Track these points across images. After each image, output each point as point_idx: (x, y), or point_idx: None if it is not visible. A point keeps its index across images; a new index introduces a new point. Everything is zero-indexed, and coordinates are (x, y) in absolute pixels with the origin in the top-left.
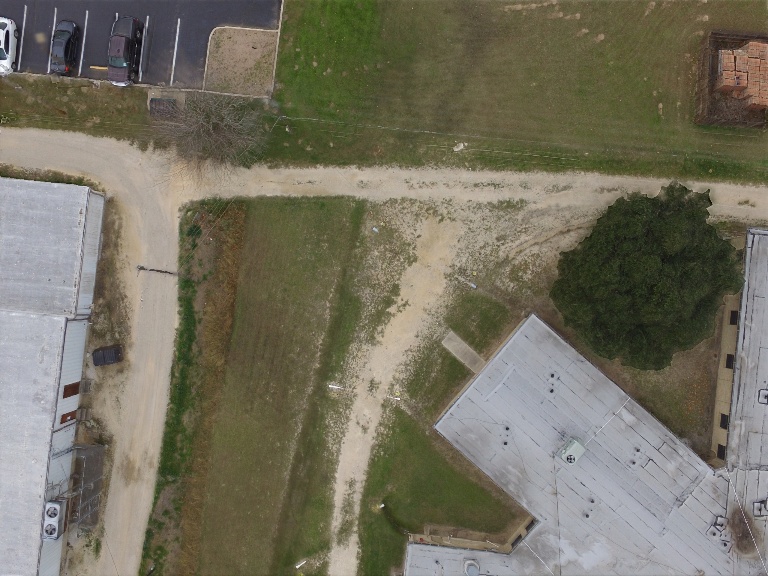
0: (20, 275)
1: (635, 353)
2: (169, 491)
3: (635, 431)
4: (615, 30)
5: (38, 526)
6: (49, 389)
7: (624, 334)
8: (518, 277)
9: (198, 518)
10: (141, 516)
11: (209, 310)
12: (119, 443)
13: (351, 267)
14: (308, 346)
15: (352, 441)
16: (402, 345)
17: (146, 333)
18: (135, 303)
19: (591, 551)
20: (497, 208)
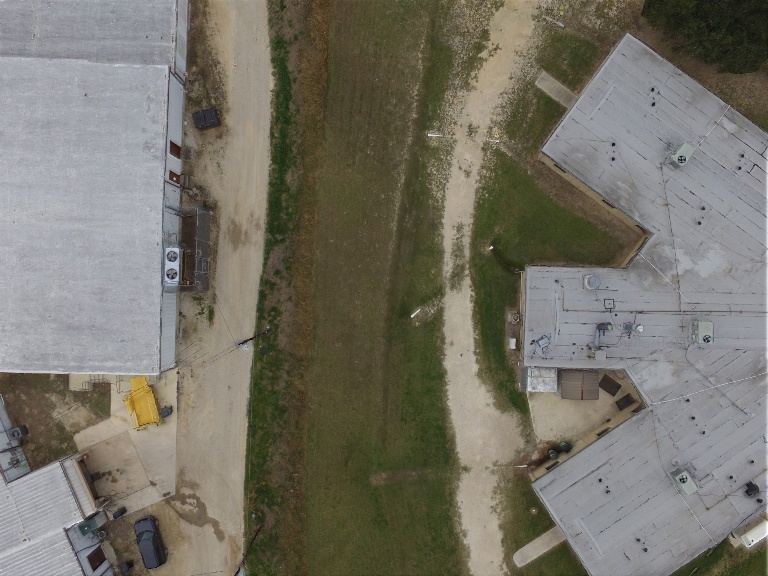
0: (117, 34)
1: (737, 45)
2: (278, 251)
3: (738, 138)
4: None
5: (158, 273)
6: (158, 137)
7: (724, 27)
8: (604, 14)
9: (309, 275)
10: (252, 279)
11: (304, 67)
12: (223, 209)
13: (439, 18)
14: (404, 97)
15: (456, 186)
16: (497, 88)
17: (242, 97)
18: (228, 69)
19: (706, 258)
20: None
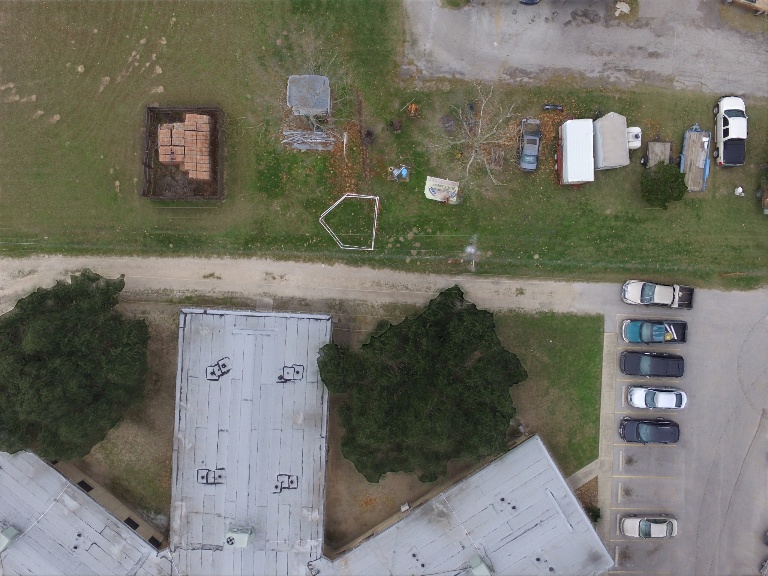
0: None
1: (36, 446)
2: None
3: (77, 516)
4: (71, 109)
5: None
6: None
7: (23, 428)
8: None
9: None
10: None
11: None
12: None
13: None
14: None
15: None
16: None
17: None
18: None
19: None
20: None
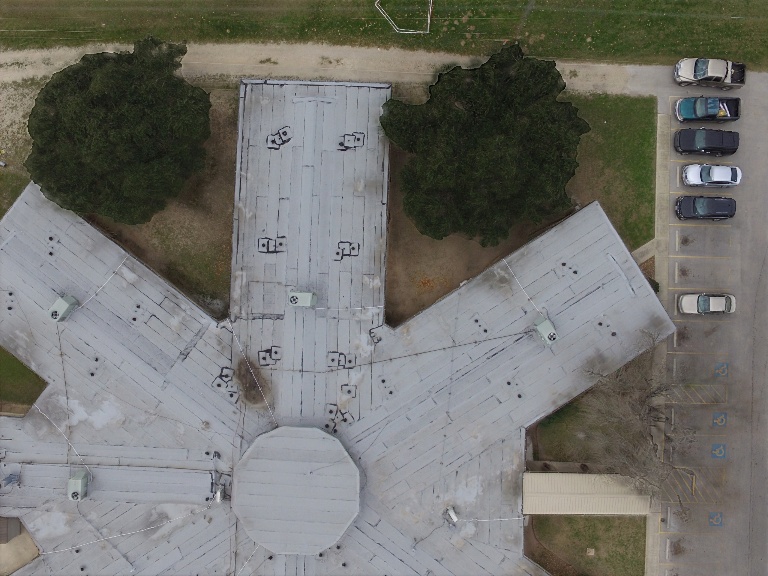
0: None
1: (99, 203)
2: None
3: (136, 288)
4: None
5: None
6: None
7: (87, 185)
8: None
9: None
10: None
11: None
12: None
13: None
14: None
15: None
16: None
17: None
18: None
19: (100, 409)
20: (22, 86)
